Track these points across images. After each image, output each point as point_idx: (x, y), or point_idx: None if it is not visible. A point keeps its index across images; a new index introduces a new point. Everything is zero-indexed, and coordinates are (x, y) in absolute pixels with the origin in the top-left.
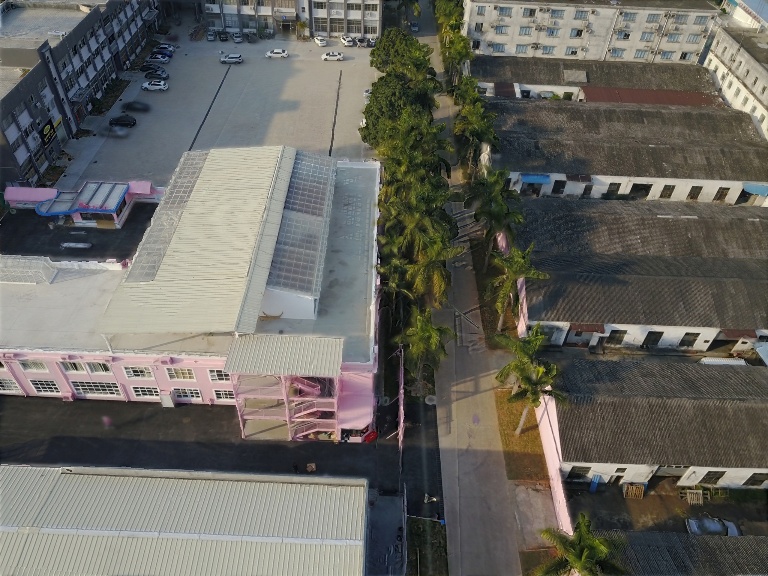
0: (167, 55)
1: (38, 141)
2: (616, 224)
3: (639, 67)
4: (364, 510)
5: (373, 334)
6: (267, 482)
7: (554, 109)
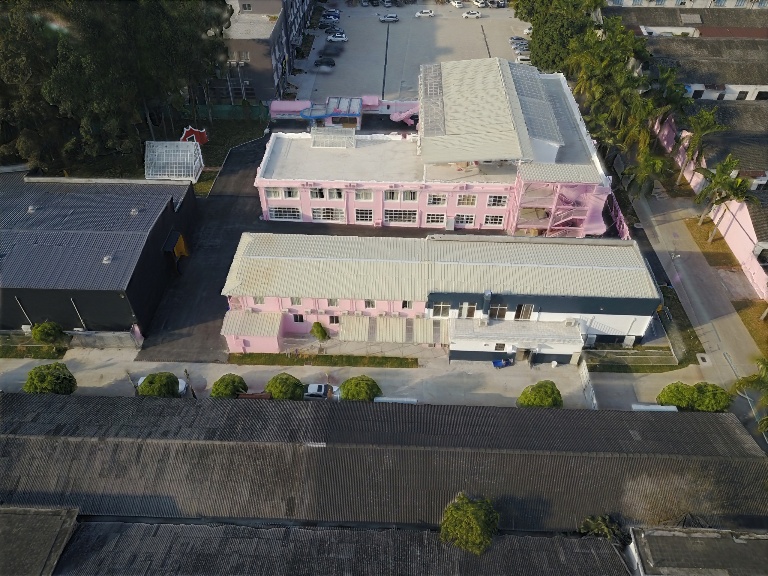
0: (336, 16)
1: (281, 71)
2: (757, 112)
3: (745, 10)
4: (640, 254)
5: (602, 171)
6: (566, 244)
7: (682, 41)
